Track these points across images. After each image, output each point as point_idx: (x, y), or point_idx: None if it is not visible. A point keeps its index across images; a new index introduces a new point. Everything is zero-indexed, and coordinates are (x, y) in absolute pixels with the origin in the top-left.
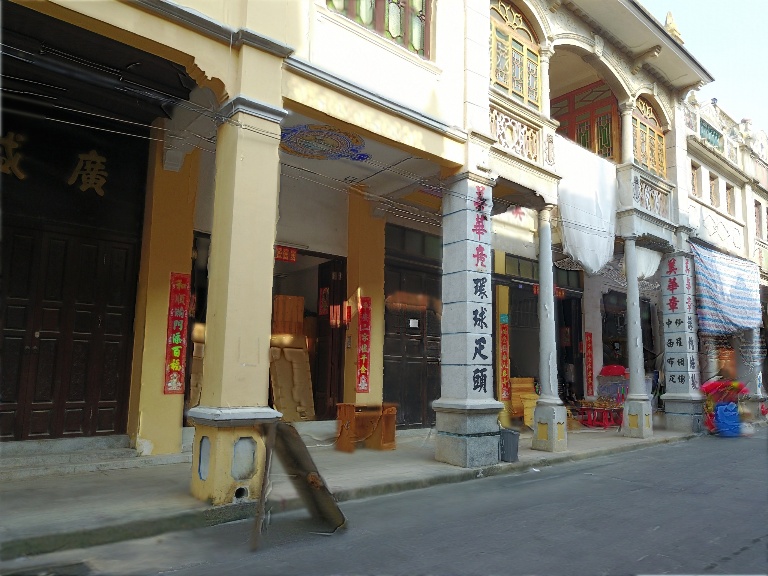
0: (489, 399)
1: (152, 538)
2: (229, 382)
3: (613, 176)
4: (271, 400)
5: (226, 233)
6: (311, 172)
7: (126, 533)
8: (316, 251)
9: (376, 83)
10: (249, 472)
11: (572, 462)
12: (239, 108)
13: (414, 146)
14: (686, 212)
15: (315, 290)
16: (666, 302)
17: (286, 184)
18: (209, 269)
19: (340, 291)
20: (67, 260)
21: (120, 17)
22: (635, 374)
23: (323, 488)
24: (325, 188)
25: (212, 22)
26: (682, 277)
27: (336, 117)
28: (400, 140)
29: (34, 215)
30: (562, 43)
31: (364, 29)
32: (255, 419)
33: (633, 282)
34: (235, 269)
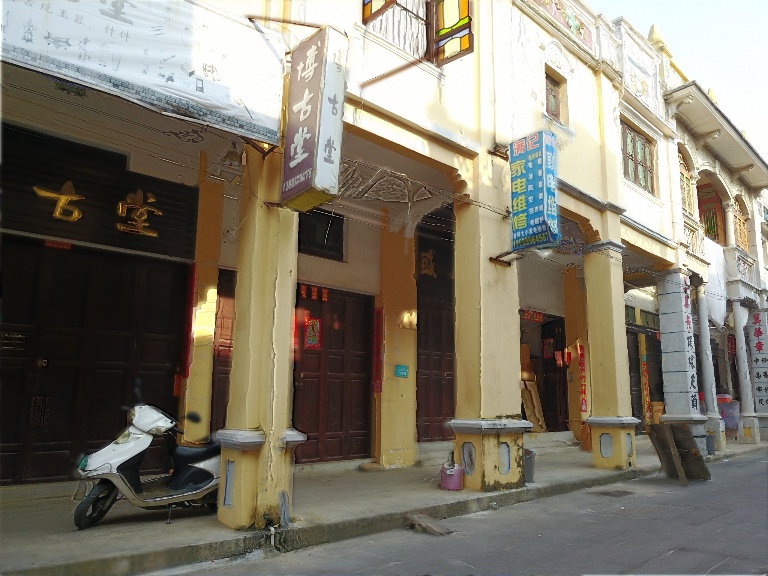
0: (699, 414)
1: (616, 484)
2: (620, 402)
3: (722, 256)
4: (526, 417)
5: (608, 318)
6: (555, 262)
7: (607, 481)
8: (553, 314)
9: (642, 219)
10: (630, 453)
11: (738, 457)
12: (609, 247)
13: (657, 255)
14: (764, 279)
15: (540, 340)
16: (753, 345)
17: (539, 270)
18: (589, 337)
19: (561, 341)
20: (453, 327)
21: (570, 204)
22: (747, 398)
23: (701, 457)
24: (557, 271)
25: (599, 201)
26: (766, 327)
27: (631, 243)
28: (653, 252)
29: (441, 300)
30: (701, 170)
31: (638, 187)
32: (632, 423)
33: (741, 332)
34: (616, 339)
